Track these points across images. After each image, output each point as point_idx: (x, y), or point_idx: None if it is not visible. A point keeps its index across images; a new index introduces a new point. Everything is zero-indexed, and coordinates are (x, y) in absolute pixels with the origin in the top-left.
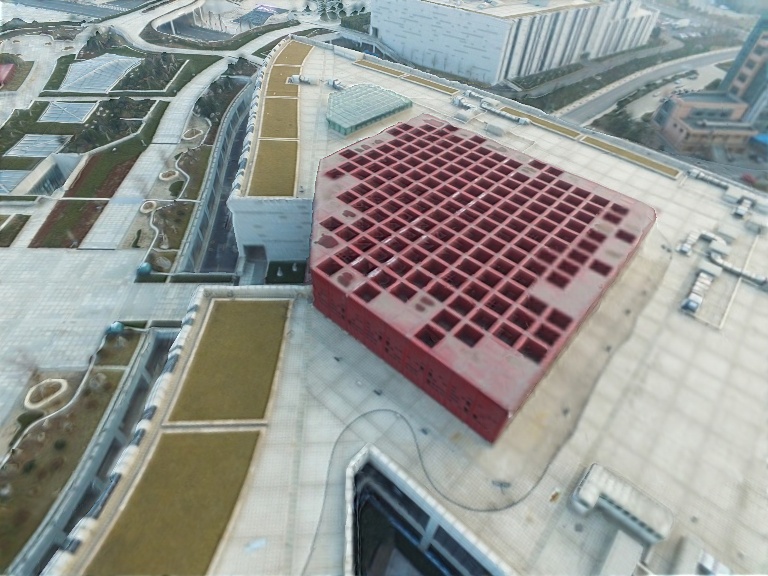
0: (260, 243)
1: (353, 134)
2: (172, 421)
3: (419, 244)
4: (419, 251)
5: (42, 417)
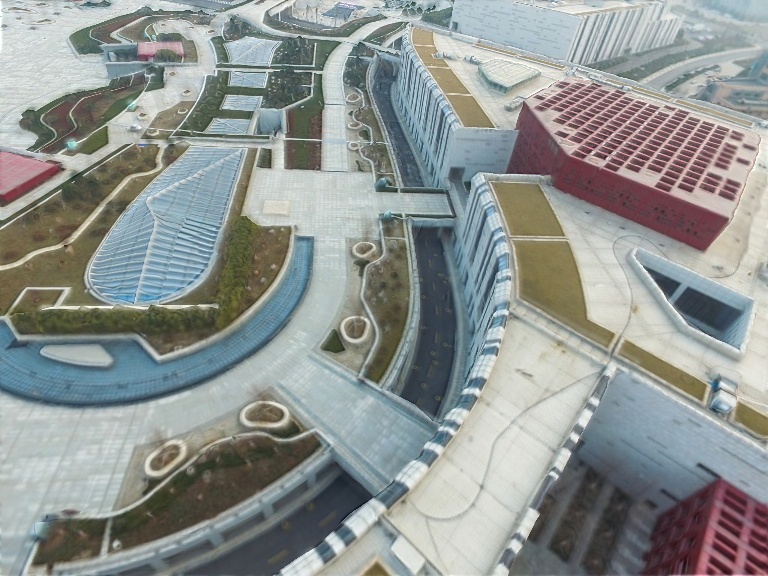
0: (463, 166)
1: (510, 93)
2: (514, 235)
3: (624, 146)
4: (627, 150)
5: (370, 262)
